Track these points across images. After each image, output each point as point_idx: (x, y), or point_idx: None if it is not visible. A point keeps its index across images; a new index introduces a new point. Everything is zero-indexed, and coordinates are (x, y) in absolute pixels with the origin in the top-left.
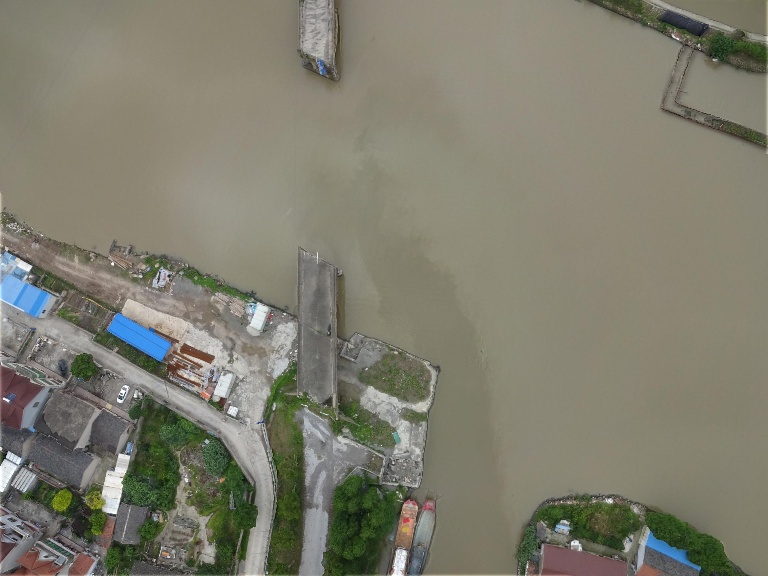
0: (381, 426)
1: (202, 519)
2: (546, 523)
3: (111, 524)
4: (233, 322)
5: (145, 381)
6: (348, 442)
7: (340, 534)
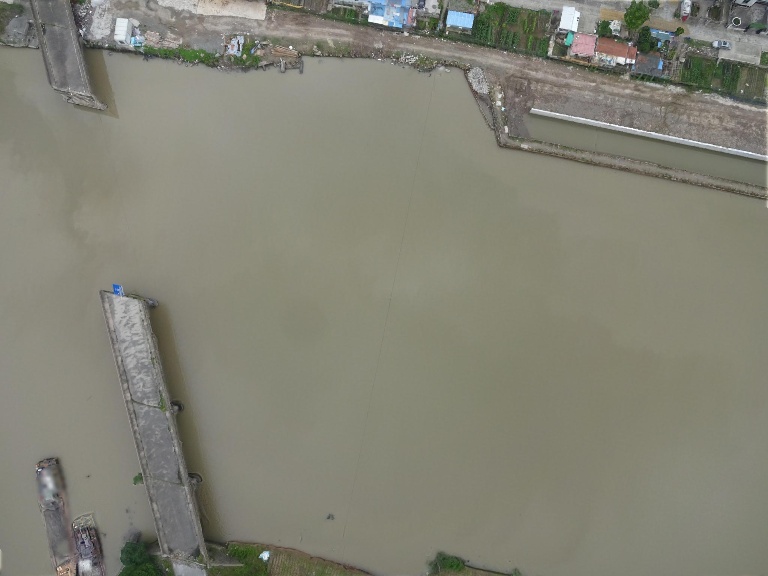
0: None
1: None
2: None
3: None
4: (154, 25)
5: None
6: None
7: None
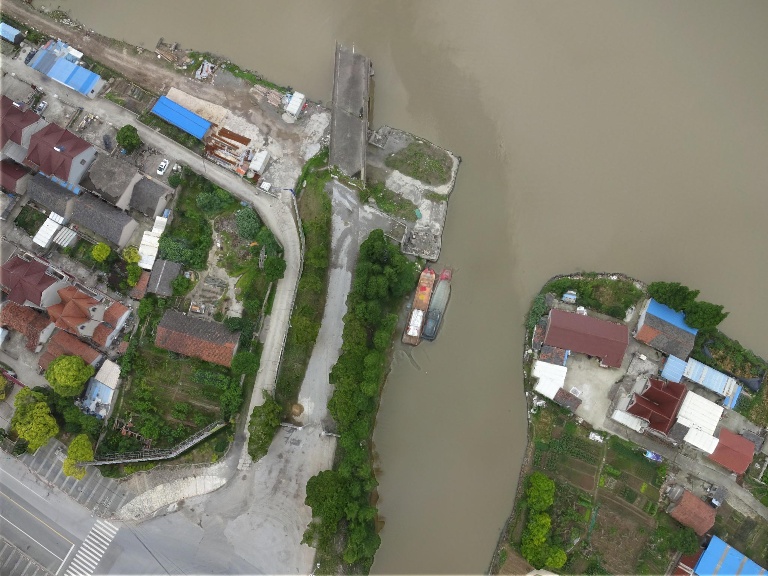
0: (404, 202)
1: (231, 280)
2: (554, 295)
3: (146, 278)
4: (270, 111)
5: (184, 157)
6: (373, 211)
7: (366, 265)
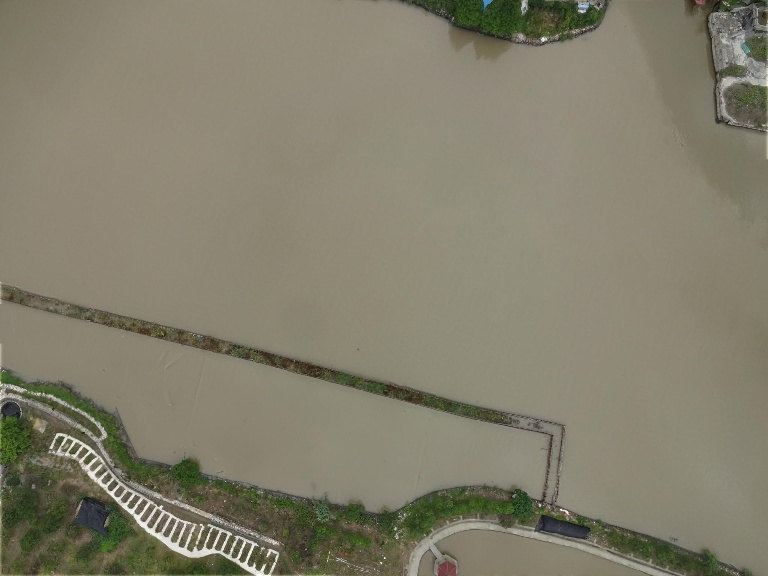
0: (763, 55)
1: None
2: None
3: None
4: None
5: None
6: None
7: None
